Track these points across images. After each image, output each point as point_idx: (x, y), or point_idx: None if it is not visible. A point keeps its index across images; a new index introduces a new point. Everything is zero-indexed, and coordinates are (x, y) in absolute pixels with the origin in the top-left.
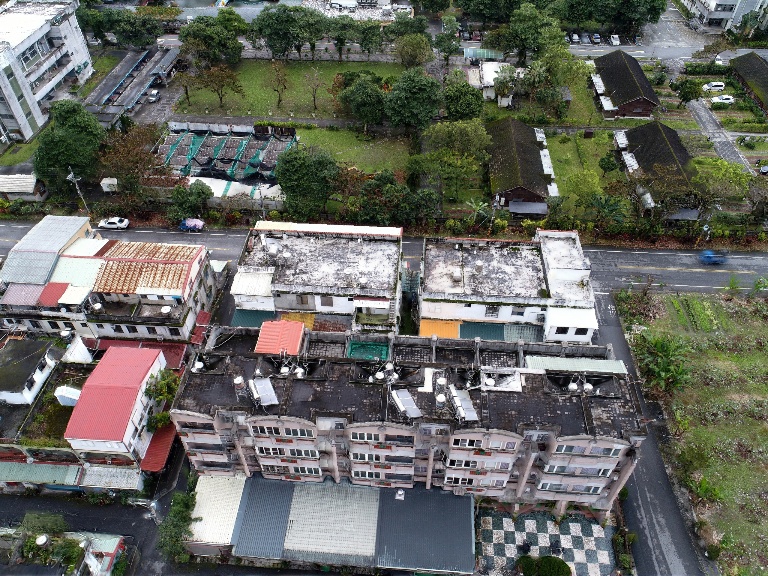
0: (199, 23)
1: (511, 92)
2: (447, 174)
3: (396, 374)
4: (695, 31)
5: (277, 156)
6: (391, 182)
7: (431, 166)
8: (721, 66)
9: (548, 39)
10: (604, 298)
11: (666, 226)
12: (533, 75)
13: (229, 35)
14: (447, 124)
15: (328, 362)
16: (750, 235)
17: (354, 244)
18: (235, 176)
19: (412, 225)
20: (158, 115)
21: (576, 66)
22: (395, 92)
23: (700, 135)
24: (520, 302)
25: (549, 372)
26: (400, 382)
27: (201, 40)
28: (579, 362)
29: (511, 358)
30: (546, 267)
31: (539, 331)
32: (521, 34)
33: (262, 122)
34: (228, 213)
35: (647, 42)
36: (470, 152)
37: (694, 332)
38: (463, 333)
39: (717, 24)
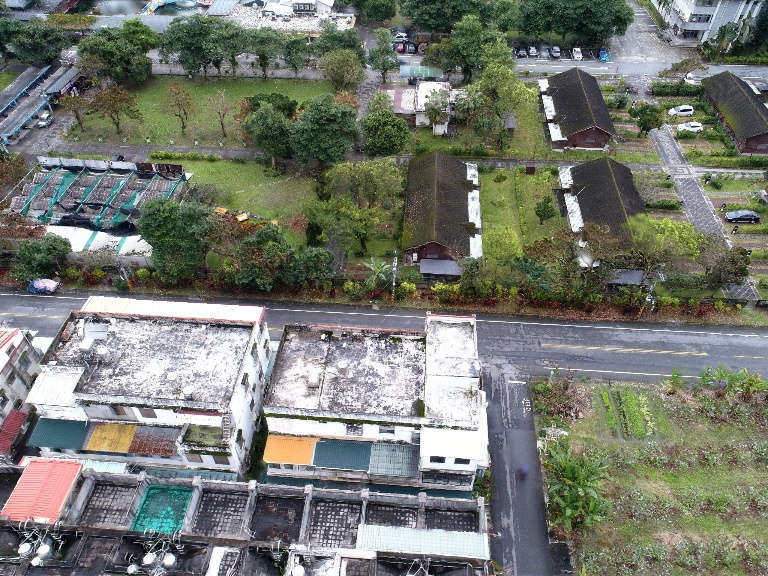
0: (101, 36)
1: (446, 118)
2: (342, 229)
3: (172, 557)
4: (668, 43)
5: (142, 206)
6: (274, 239)
7: (325, 218)
8: (692, 86)
9: (492, 57)
10: (519, 389)
11: (605, 291)
12: (468, 101)
13: (134, 50)
14: (350, 166)
15: (85, 536)
16: (705, 303)
17: (198, 331)
18: (103, 225)
19: (305, 287)
20: (45, 143)
21: (516, 91)
22: (300, 123)
23: (659, 172)
24: (386, 420)
25: (381, 556)
26: (172, 572)
27: (100, 56)
28: (428, 536)
29: (353, 512)
30: (425, 371)
31: (415, 453)
32: (463, 50)
33: (158, 153)
34: (86, 272)
35: (613, 56)
36: (378, 198)
37: (623, 438)
38: (318, 455)
39: (693, 36)
